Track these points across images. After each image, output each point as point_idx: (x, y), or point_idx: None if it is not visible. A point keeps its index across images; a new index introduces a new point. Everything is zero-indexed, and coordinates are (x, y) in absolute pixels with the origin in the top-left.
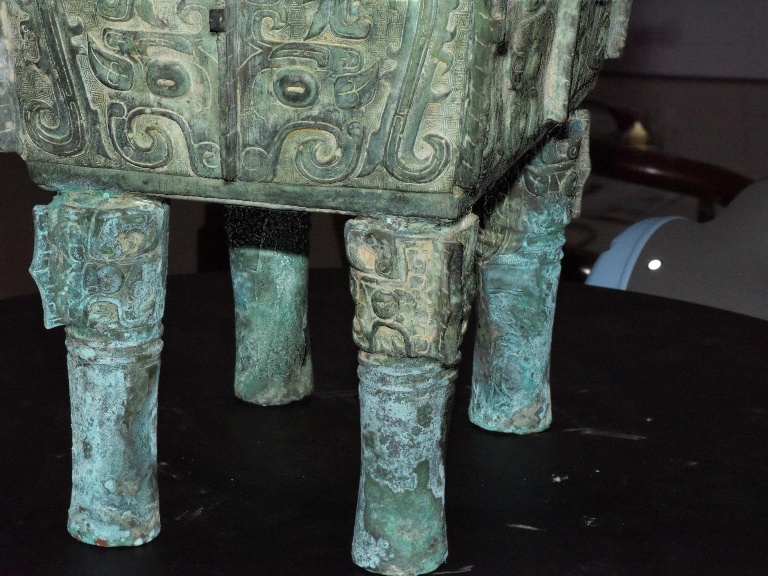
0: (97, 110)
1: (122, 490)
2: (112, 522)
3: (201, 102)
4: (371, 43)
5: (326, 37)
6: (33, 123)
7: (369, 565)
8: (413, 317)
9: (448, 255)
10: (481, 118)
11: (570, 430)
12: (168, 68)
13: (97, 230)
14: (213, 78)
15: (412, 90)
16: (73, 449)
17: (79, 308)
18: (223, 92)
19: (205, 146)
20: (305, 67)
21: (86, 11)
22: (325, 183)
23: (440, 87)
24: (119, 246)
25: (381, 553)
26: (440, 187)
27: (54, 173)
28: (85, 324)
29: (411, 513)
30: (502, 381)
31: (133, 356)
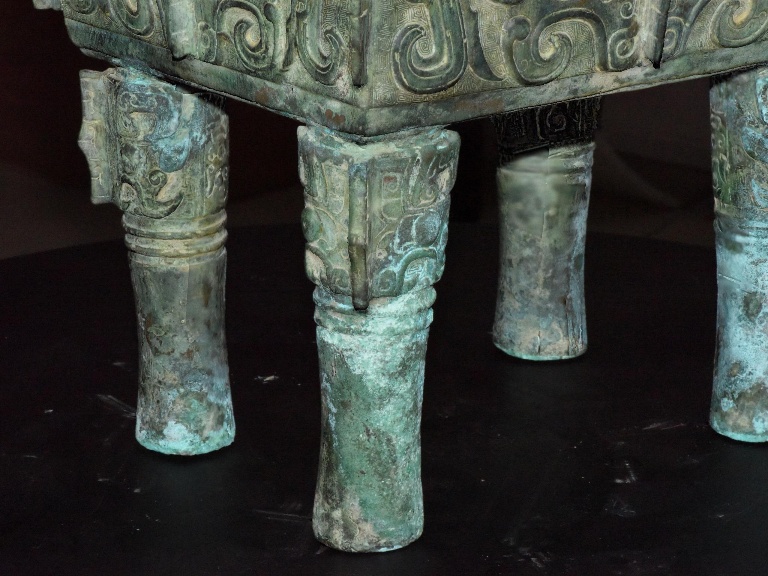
0: None
1: None
2: None
3: None
4: None
5: None
6: None
7: None
8: None
9: None
10: None
11: None
12: None
13: None
14: None
15: None
16: None
17: None
18: None
19: None
20: None
21: None
22: None
23: None
24: None
25: None
26: None
27: None
28: None
29: None
30: None
31: None
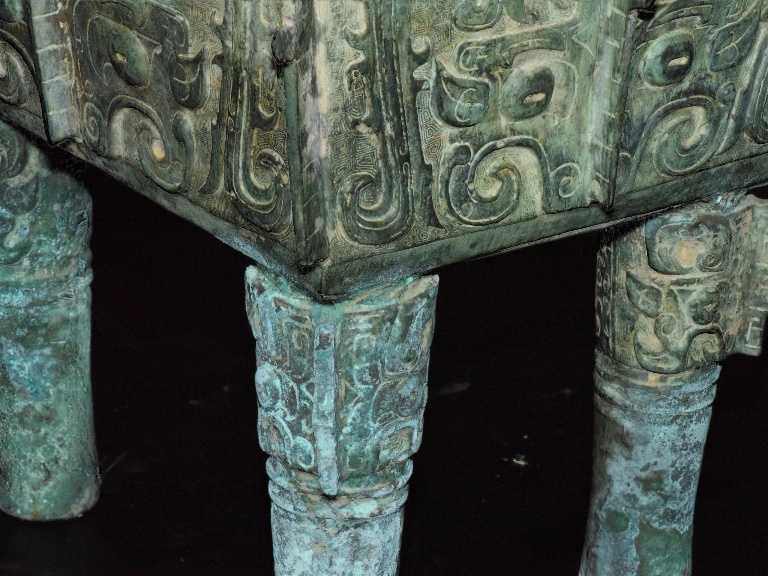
0: (431, 164)
1: None
2: None
3: (559, 112)
4: None
5: None
6: (353, 209)
7: None
8: (726, 311)
9: None
10: None
11: None
12: (540, 77)
13: (405, 333)
14: (582, 75)
15: None
16: None
17: (365, 450)
18: (625, 89)
19: (563, 171)
20: (684, 29)
21: (438, 26)
22: None
23: None
24: (420, 345)
25: None
26: None
27: (361, 272)
28: (375, 469)
29: None
30: None
31: (407, 489)
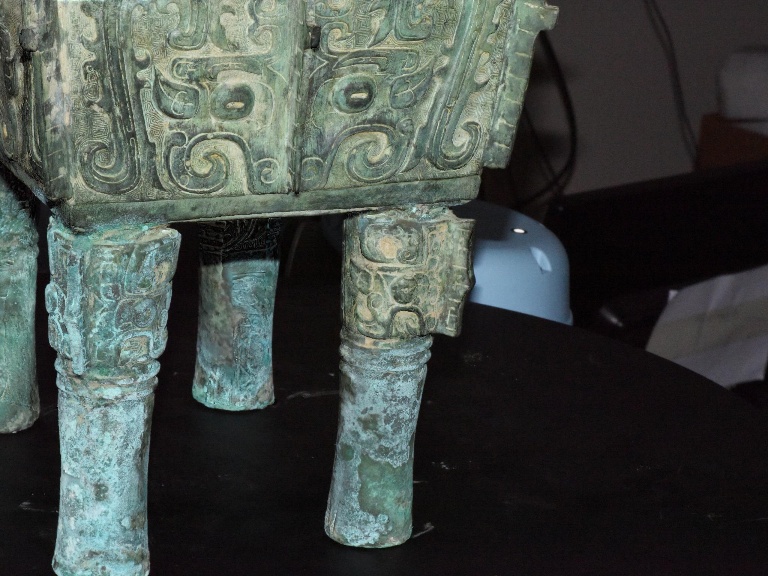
0: (155, 143)
1: (136, 524)
2: (128, 559)
3: (261, 120)
4: (428, 43)
5: (389, 42)
6: (89, 165)
7: (368, 543)
8: (426, 298)
9: (468, 233)
10: (522, 100)
11: (290, 397)
12: (239, 91)
13: (139, 265)
14: (278, 95)
15: (461, 82)
16: (75, 495)
17: (110, 348)
18: (304, 107)
19: (264, 163)
20: (366, 73)
21: (156, 43)
22: (374, 182)
23: (480, 76)
24: (155, 277)
25: (381, 528)
26: (469, 170)
27: (100, 213)
28: (117, 363)
29: (404, 484)
30: (247, 361)
31: (151, 387)
